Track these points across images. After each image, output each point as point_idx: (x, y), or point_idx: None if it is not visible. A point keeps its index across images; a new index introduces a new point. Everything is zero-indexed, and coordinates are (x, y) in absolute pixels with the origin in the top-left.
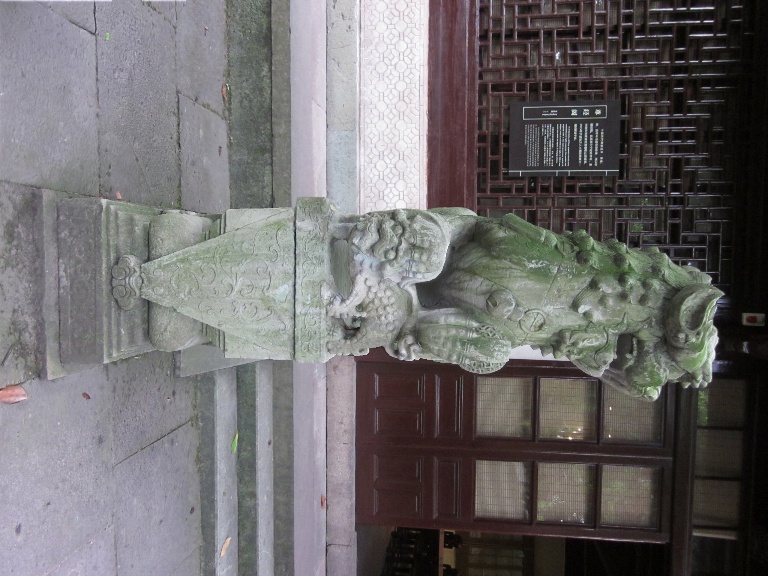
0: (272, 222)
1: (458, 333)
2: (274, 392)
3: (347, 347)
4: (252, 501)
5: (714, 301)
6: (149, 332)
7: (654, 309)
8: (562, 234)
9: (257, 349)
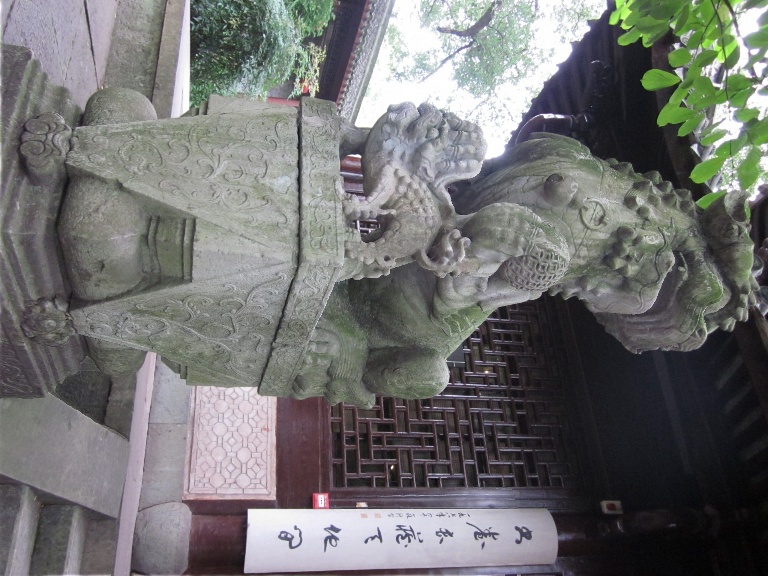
0: (270, 113)
1: (523, 210)
2: None
3: (371, 251)
4: None
5: (746, 202)
6: (63, 216)
7: (693, 218)
8: None
9: (245, 242)
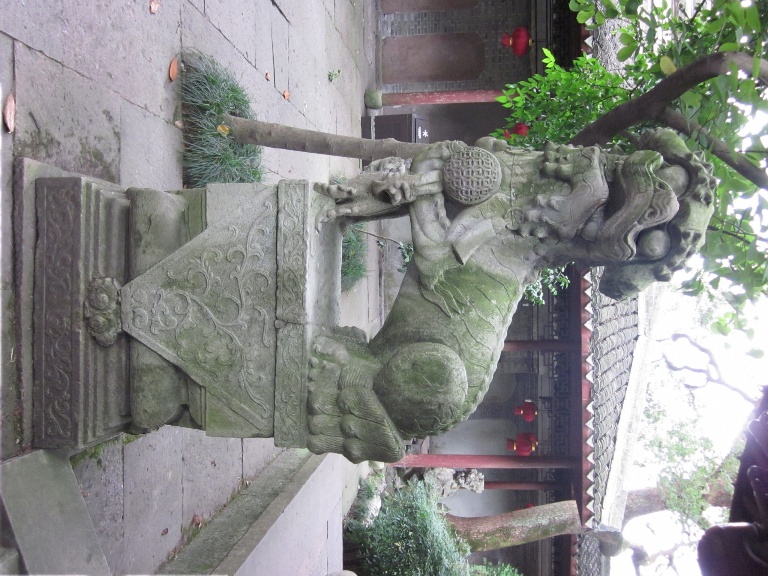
0: None
1: None
2: None
3: None
4: None
5: None
6: None
7: None
8: None
9: None
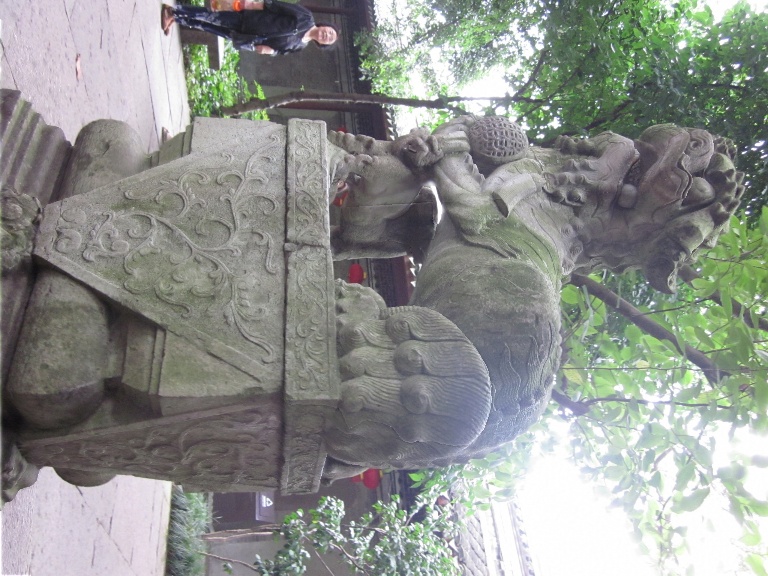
0: None
1: None
2: None
3: None
4: None
5: None
6: None
7: None
8: None
9: None
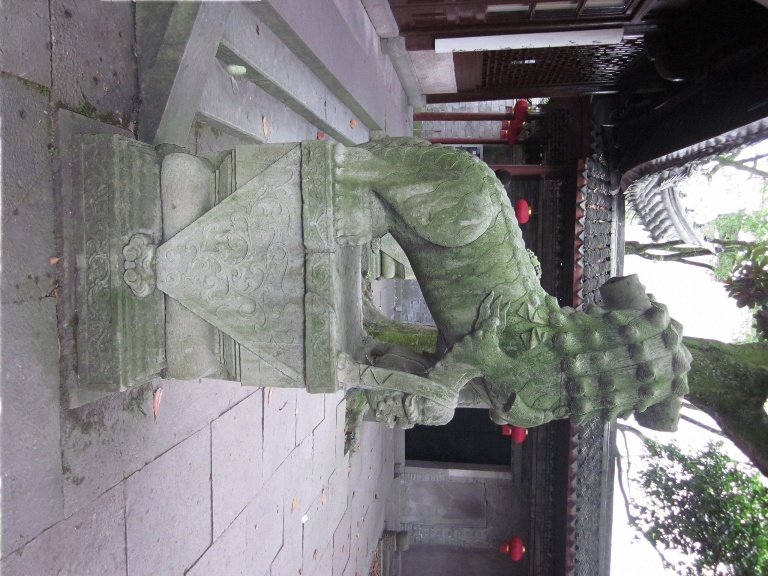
0: None
1: None
2: None
3: None
4: (268, 82)
5: None
6: None
7: None
8: (566, 373)
9: None
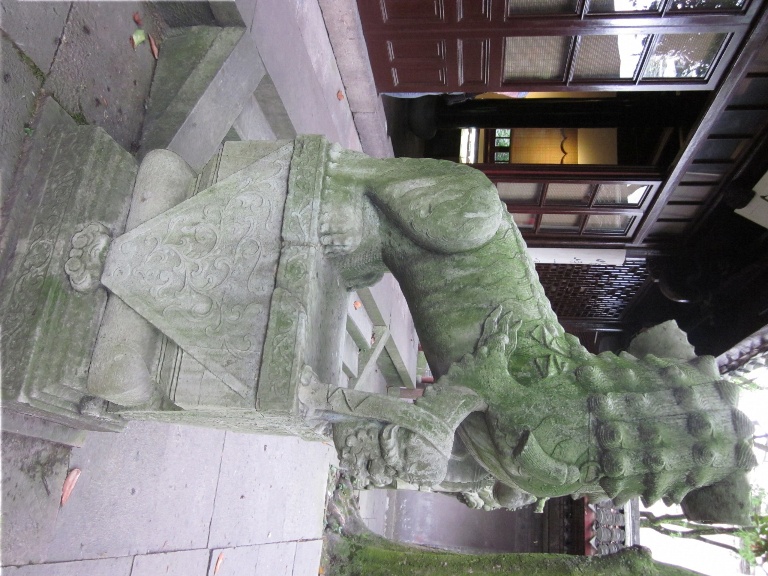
0: None
1: None
2: (260, 106)
3: None
4: None
5: None
6: None
7: None
8: (595, 412)
9: None
